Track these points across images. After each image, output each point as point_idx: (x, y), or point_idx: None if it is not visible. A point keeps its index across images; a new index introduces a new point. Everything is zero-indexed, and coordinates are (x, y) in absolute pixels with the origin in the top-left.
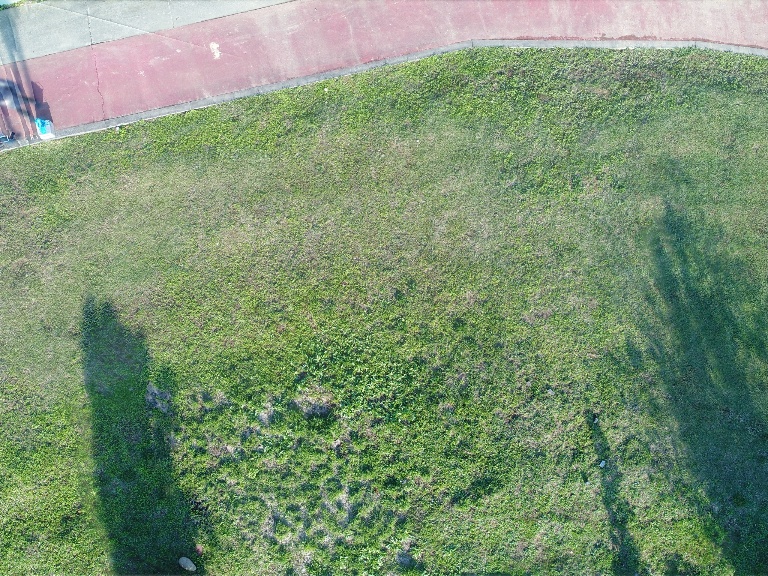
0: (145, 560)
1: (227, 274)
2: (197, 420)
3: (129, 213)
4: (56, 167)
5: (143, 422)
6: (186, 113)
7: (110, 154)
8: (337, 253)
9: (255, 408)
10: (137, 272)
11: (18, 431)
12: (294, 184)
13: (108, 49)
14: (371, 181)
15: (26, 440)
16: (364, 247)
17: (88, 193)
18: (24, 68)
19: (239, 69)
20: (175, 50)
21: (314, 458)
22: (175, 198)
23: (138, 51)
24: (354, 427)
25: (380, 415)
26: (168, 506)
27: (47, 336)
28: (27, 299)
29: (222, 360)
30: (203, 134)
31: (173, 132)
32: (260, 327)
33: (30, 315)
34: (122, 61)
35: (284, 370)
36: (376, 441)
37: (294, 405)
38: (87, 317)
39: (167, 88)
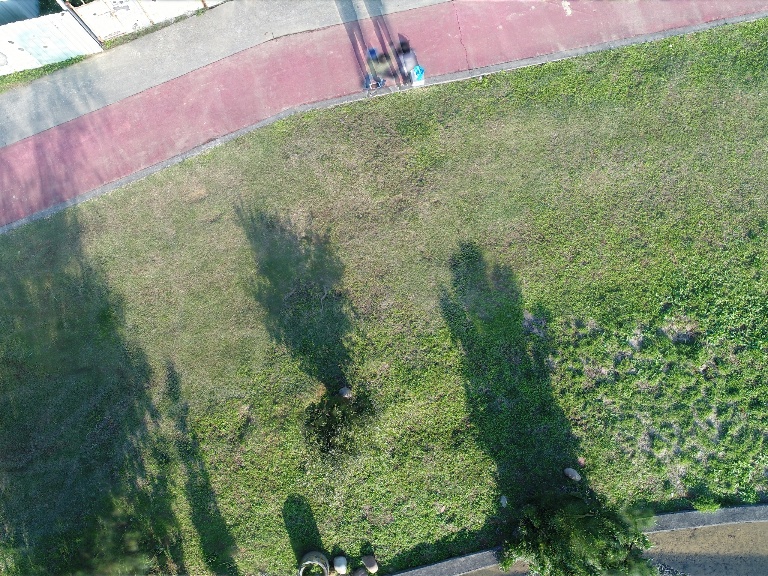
0: (532, 470)
1: (591, 213)
2: (573, 344)
3: (497, 155)
4: (425, 112)
5: (522, 345)
6: (543, 65)
7: (475, 101)
8: (691, 195)
9: (627, 334)
10: (508, 209)
11: (407, 352)
12: (648, 132)
13: (468, 5)
14: (719, 130)
15: (416, 360)
16: (716, 190)
17: (457, 136)
18: (390, 21)
19: (590, 25)
20: (530, 7)
21: (684, 381)
22: (538, 142)
23: (496, 7)
24: (719, 353)
25: (742, 343)
26: (550, 422)
27: (428, 266)
28: (407, 232)
29: (591, 291)
30: (561, 84)
31: (532, 82)
32: (626, 261)
33: (410, 247)
34: (481, 16)
35: (650, 301)
36: (739, 367)
37: (662, 332)
38: (464, 249)
39: (525, 42)
